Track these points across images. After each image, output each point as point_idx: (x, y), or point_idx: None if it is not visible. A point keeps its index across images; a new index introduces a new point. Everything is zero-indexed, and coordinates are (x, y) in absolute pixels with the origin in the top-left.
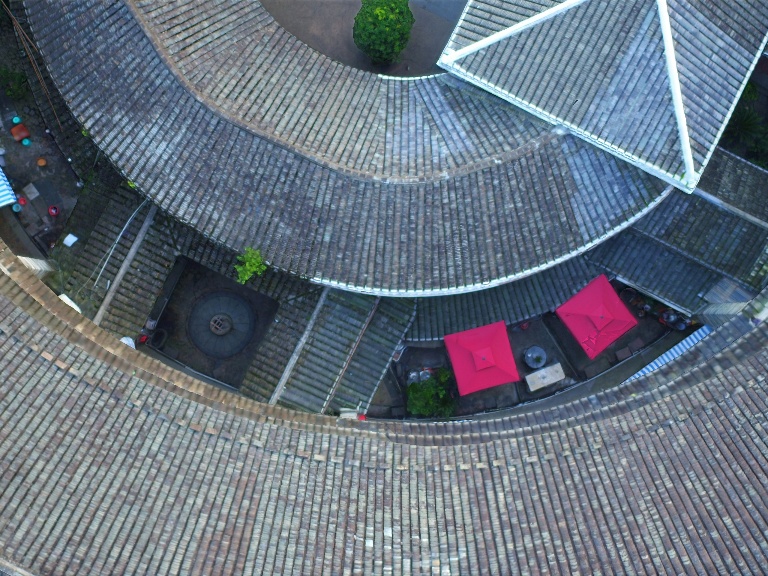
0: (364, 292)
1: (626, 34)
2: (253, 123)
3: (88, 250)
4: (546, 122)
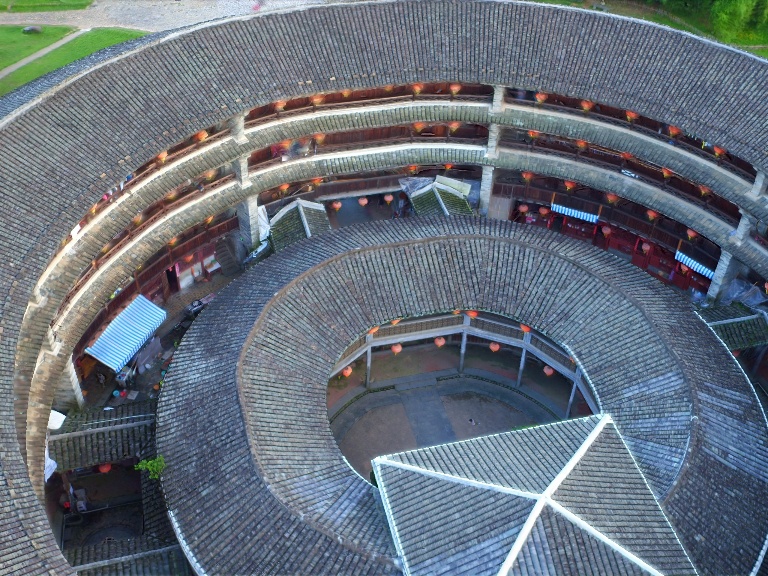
0: (184, 549)
1: (490, 530)
2: (246, 398)
3: (106, 411)
4: (396, 550)
